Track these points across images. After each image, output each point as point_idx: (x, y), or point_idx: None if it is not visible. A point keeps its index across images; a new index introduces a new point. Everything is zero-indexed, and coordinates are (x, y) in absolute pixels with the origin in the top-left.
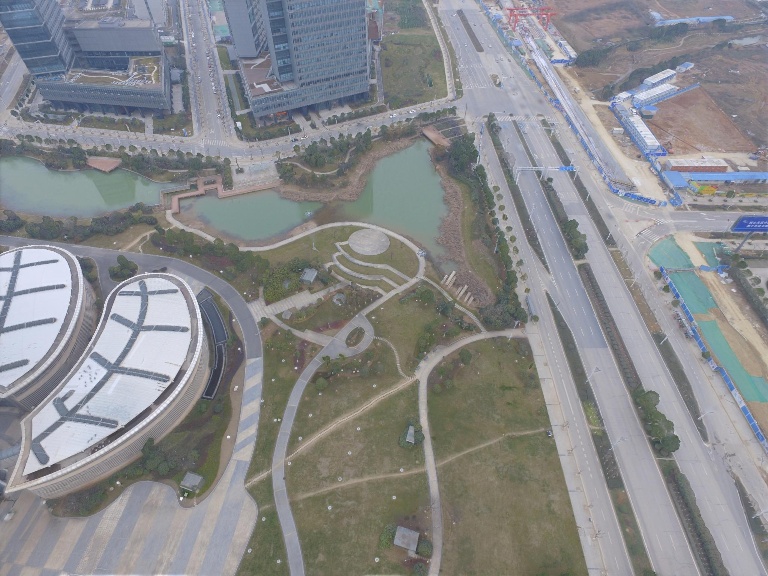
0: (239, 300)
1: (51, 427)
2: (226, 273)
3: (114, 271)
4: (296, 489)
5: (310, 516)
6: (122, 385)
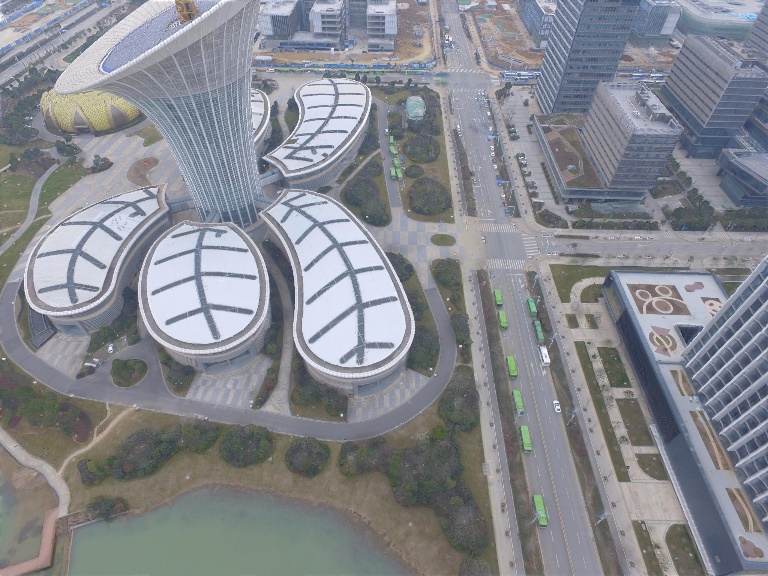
0: (4, 336)
1: (142, 200)
2: (3, 366)
3: (134, 361)
4: (21, 214)
5: (19, 204)
6: (93, 216)
